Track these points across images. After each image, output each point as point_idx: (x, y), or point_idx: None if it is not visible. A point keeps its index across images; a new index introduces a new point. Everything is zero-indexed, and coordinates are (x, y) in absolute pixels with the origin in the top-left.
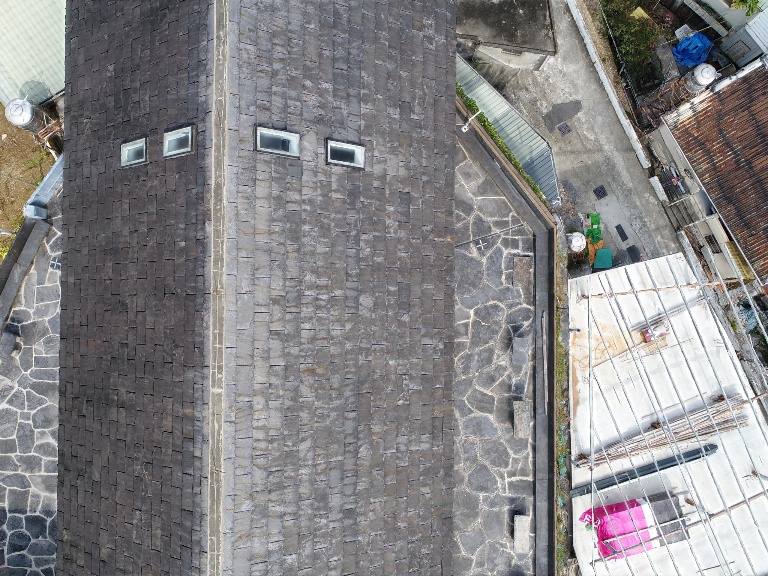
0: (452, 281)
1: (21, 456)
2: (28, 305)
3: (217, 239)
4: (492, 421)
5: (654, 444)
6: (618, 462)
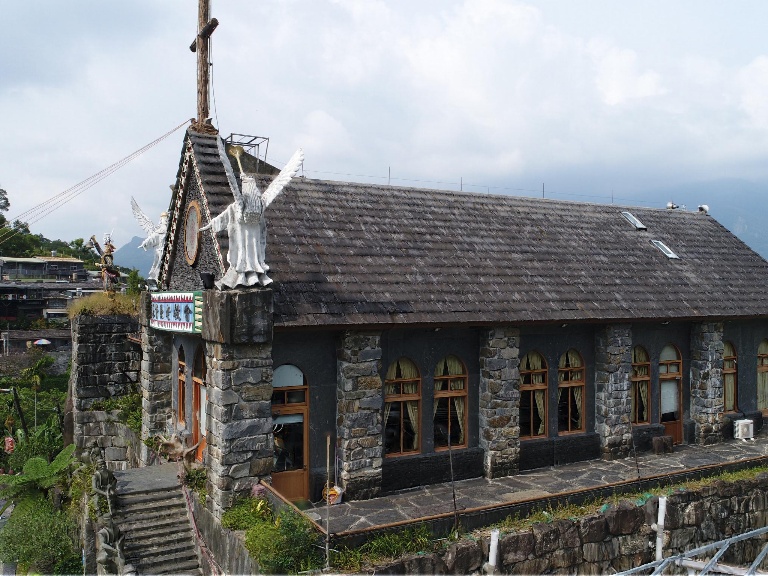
0: None
1: None
2: None
3: None
4: None
5: None
6: None
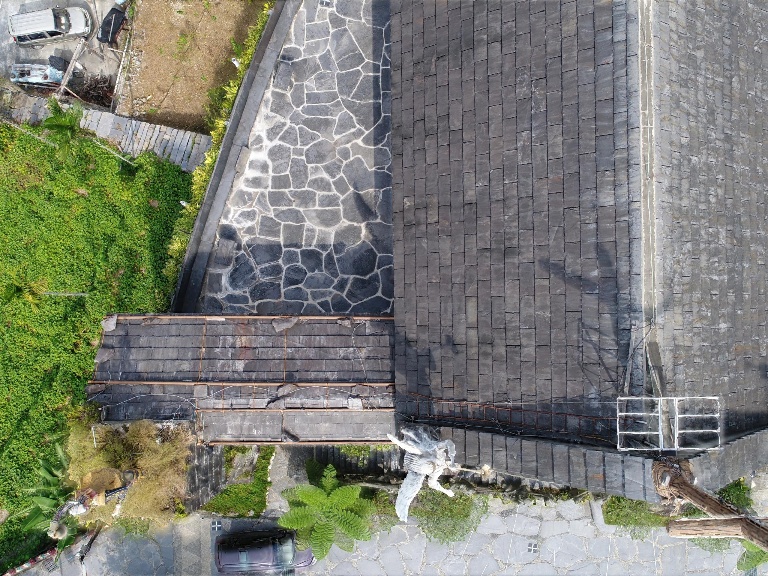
0: None
1: (295, 191)
2: (298, 42)
3: None
4: None
5: None
6: None
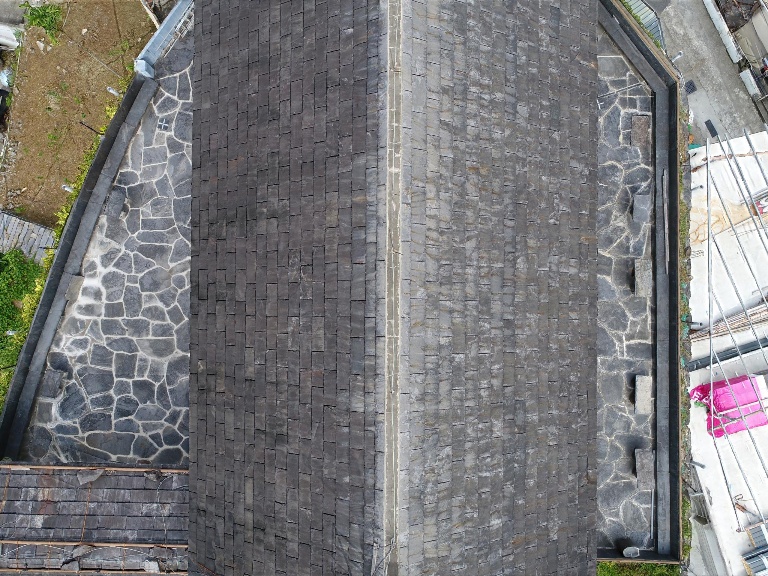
0: (595, 108)
1: (128, 320)
2: (135, 167)
3: (393, 15)
4: (610, 283)
5: (765, 318)
6: (728, 338)
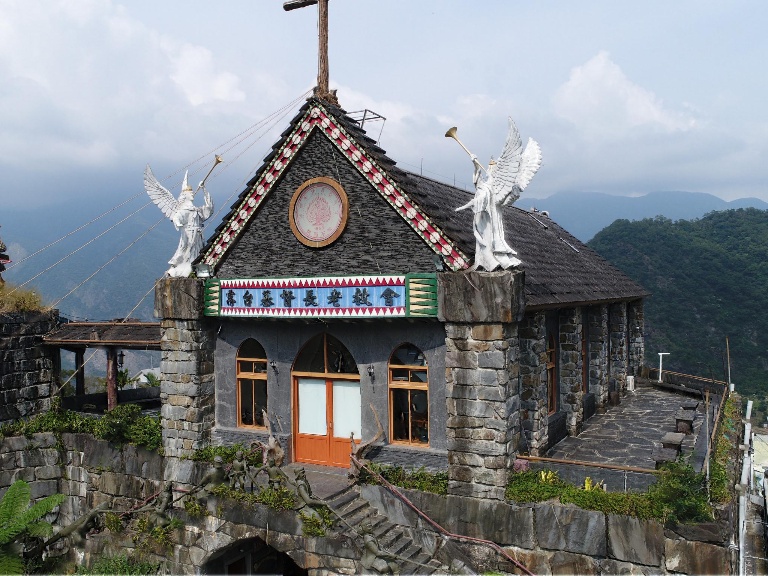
0: None
1: None
2: None
3: None
4: None
5: None
6: None
